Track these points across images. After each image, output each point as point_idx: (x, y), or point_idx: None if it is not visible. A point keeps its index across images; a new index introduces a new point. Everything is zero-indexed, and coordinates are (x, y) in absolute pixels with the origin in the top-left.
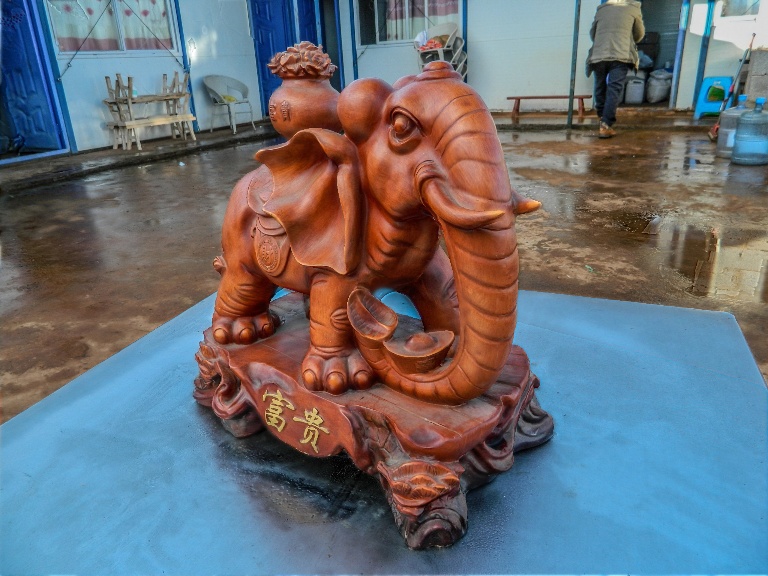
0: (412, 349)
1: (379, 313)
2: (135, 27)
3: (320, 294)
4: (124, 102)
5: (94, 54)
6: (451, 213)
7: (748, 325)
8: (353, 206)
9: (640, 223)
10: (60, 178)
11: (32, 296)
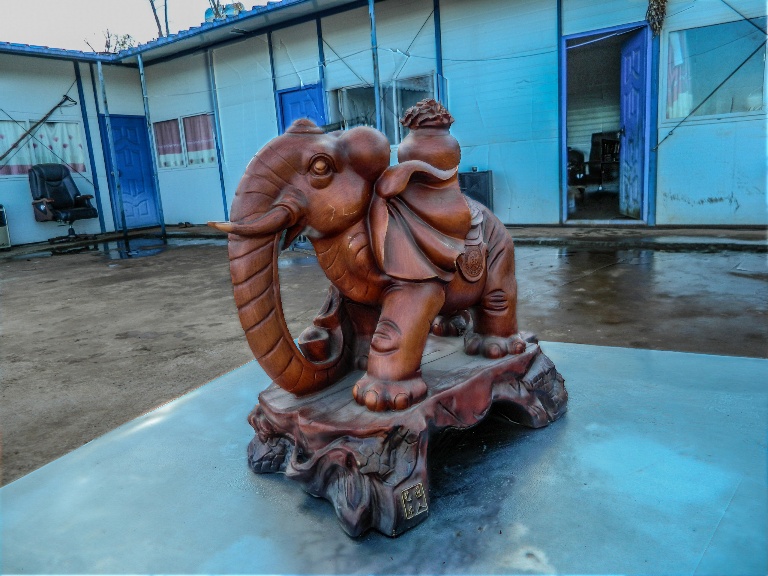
0: None
1: None
2: None
3: None
4: None
5: None
6: None
7: None
8: None
9: None
10: None
11: None
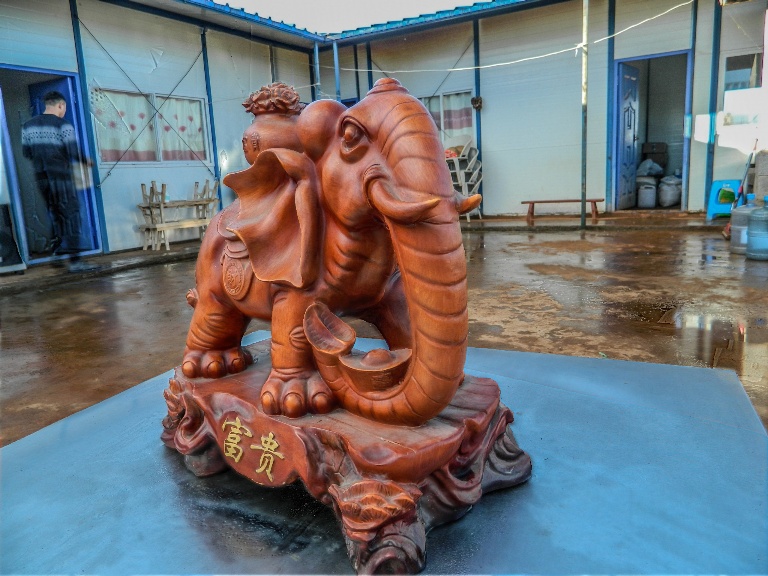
0: (368, 364)
1: (338, 330)
2: (172, 141)
3: (280, 312)
4: (157, 206)
5: (133, 164)
6: (392, 206)
7: None
8: (309, 219)
9: (655, 313)
10: (89, 275)
11: (43, 379)
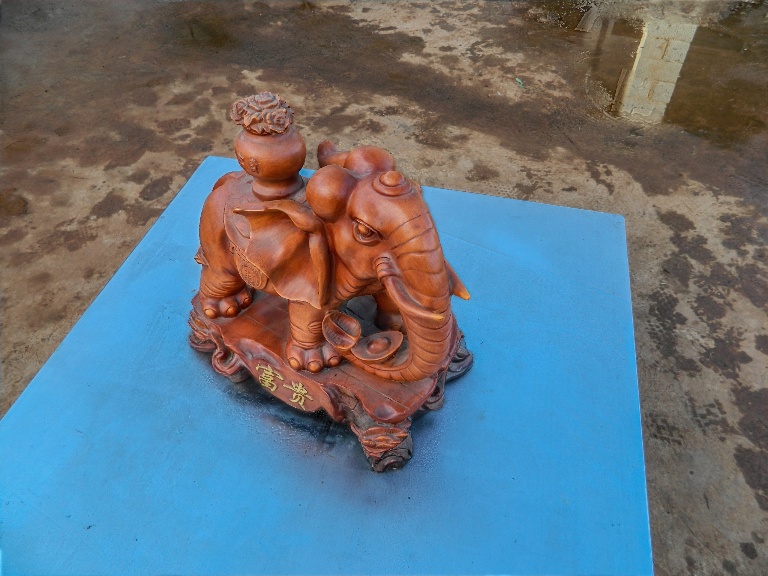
0: (373, 353)
1: (346, 323)
2: None
3: (298, 311)
4: None
5: None
6: (405, 309)
7: (652, 151)
8: (324, 266)
9: (575, 15)
10: None
11: None
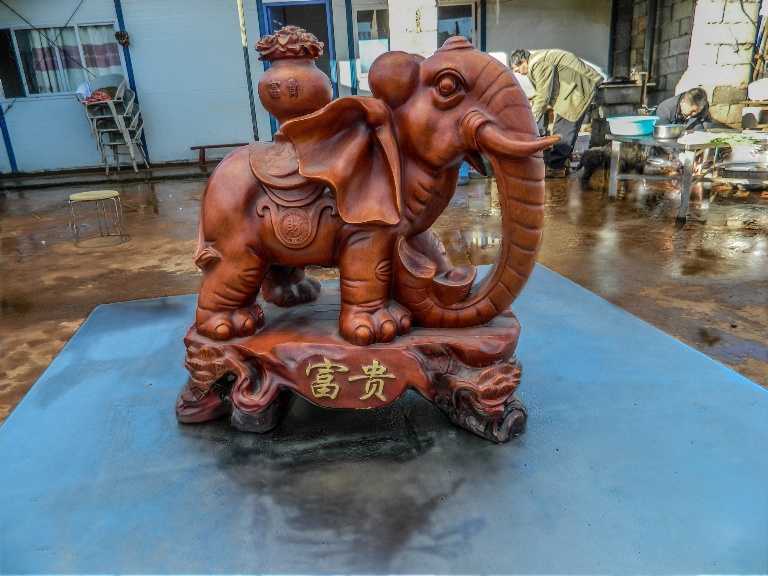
0: (455, 280)
1: None
2: None
3: (362, 251)
4: None
5: None
6: (515, 145)
7: None
8: (398, 161)
9: None
10: None
11: None
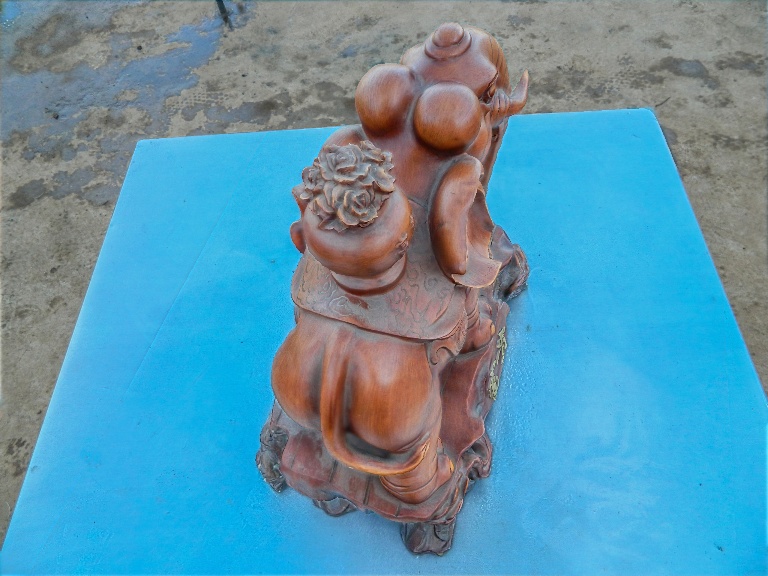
0: None
1: None
2: None
3: None
4: None
5: None
6: (525, 100)
7: None
8: None
9: None
10: None
11: None
